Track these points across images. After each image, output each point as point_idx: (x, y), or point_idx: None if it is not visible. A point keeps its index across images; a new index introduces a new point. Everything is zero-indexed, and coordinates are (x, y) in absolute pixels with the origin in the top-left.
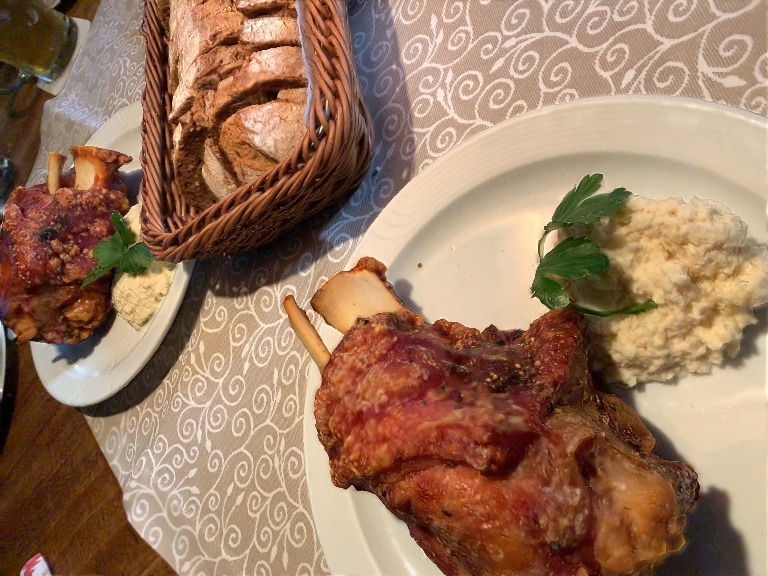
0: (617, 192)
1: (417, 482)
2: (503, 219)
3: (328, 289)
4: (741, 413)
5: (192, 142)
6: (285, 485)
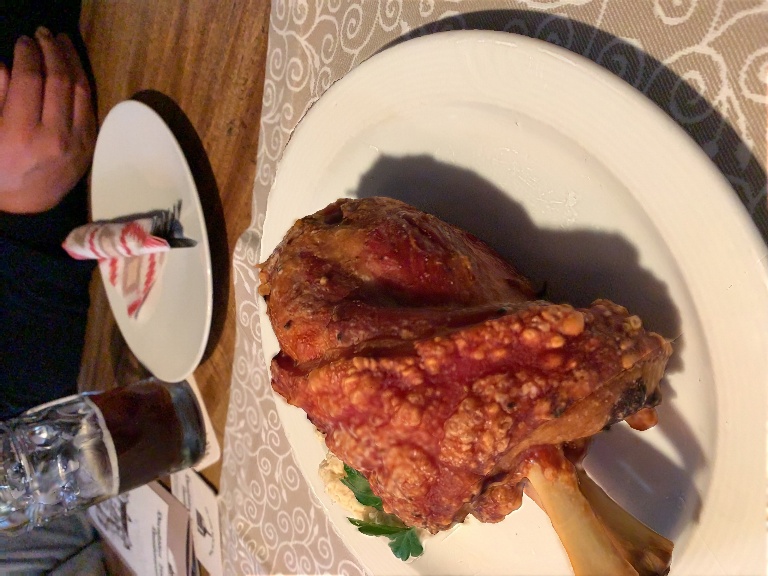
0: None
1: (314, 349)
2: (509, 568)
3: None
4: None
5: None
6: None
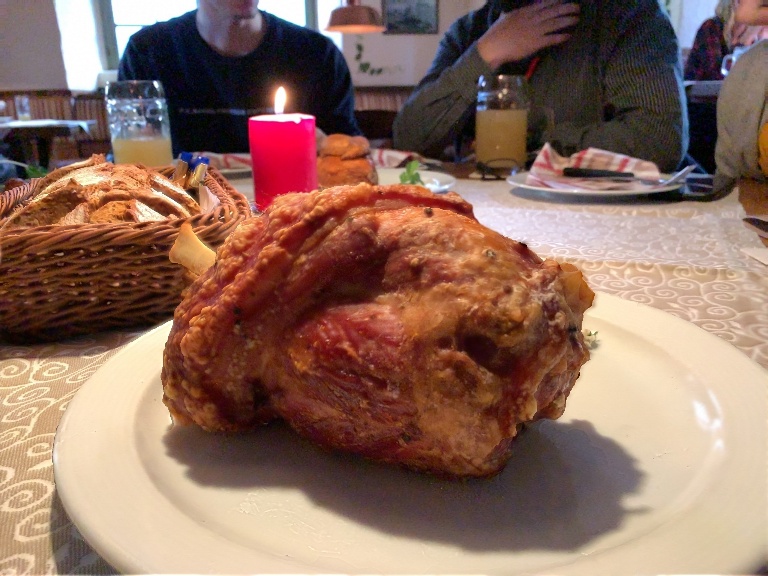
0: None
1: None
2: None
3: None
4: (576, 387)
5: (61, 202)
6: None
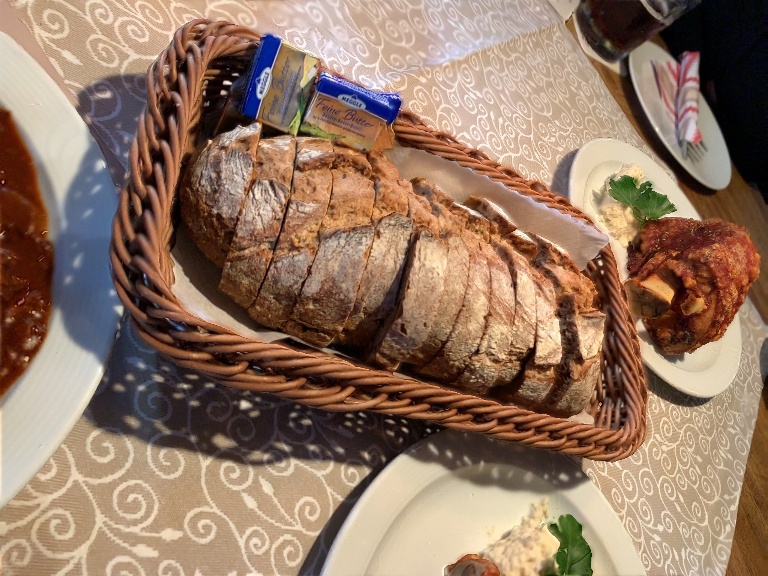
0: (623, 178)
1: None
2: None
3: (661, 296)
4: None
5: None
6: (674, 443)
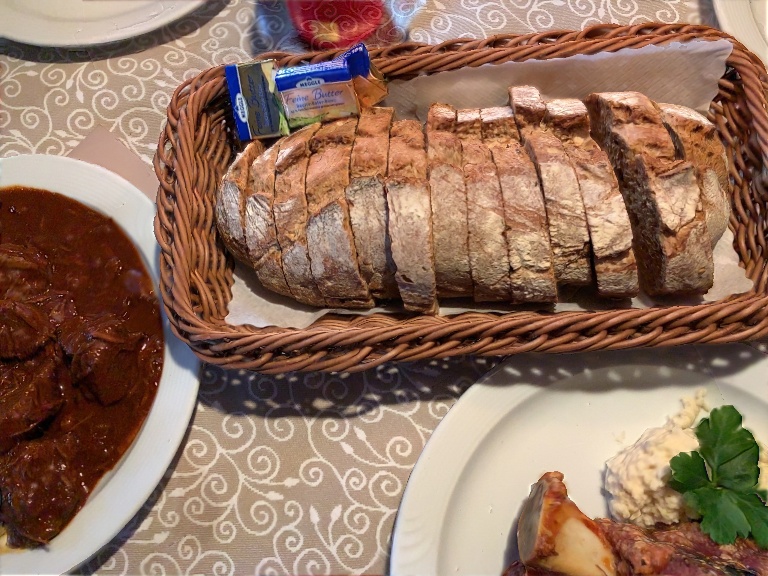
0: None
1: None
2: None
3: None
4: None
5: None
6: None
